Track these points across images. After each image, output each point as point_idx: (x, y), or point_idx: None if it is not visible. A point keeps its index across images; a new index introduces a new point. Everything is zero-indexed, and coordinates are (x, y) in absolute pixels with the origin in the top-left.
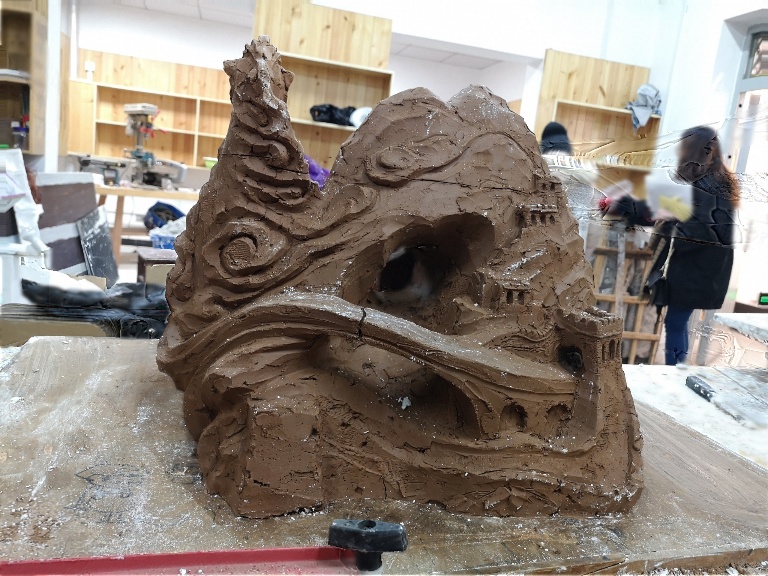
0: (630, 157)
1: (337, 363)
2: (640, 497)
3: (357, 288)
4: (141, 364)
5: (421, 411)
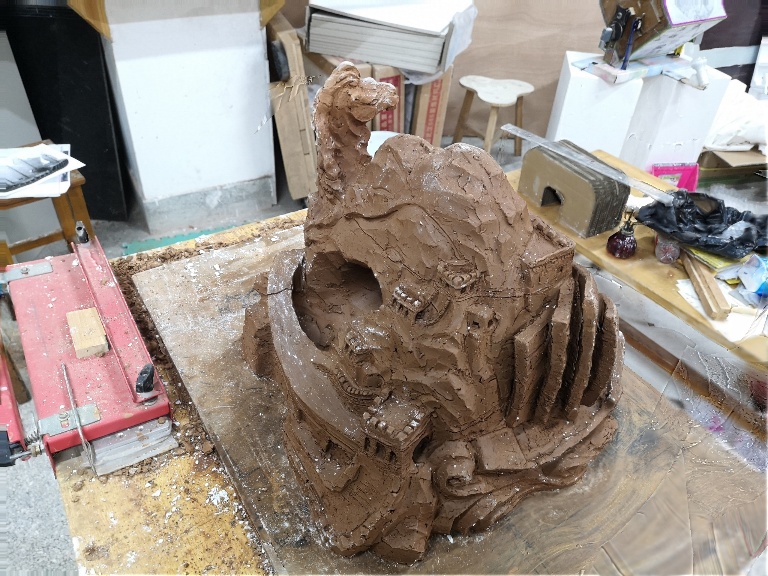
0: (760, 315)
1: (310, 312)
2: (371, 568)
3: (332, 274)
4: None
5: None
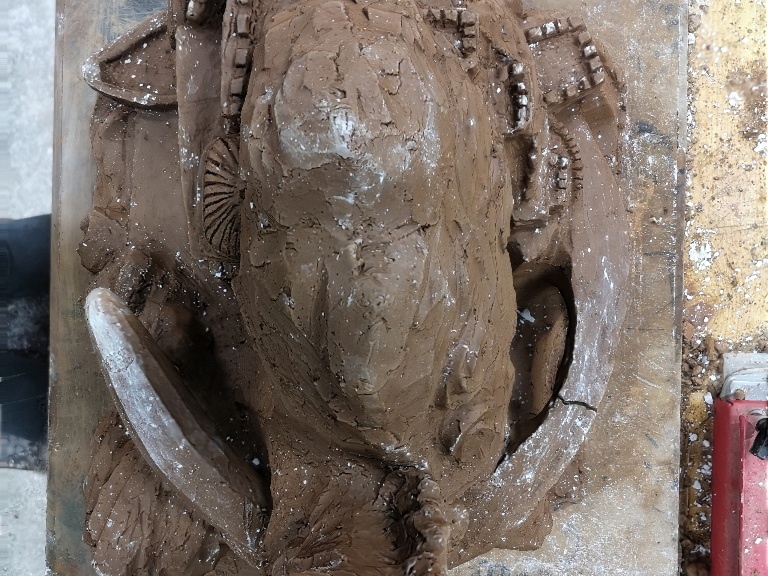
0: None
1: None
2: None
3: None
4: None
5: (536, 300)
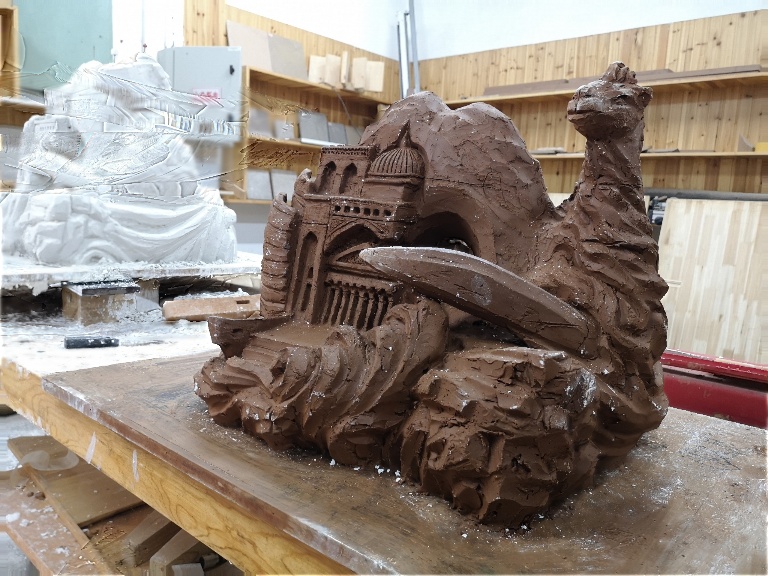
0: None
1: None
2: None
3: None
4: (628, 575)
5: None
